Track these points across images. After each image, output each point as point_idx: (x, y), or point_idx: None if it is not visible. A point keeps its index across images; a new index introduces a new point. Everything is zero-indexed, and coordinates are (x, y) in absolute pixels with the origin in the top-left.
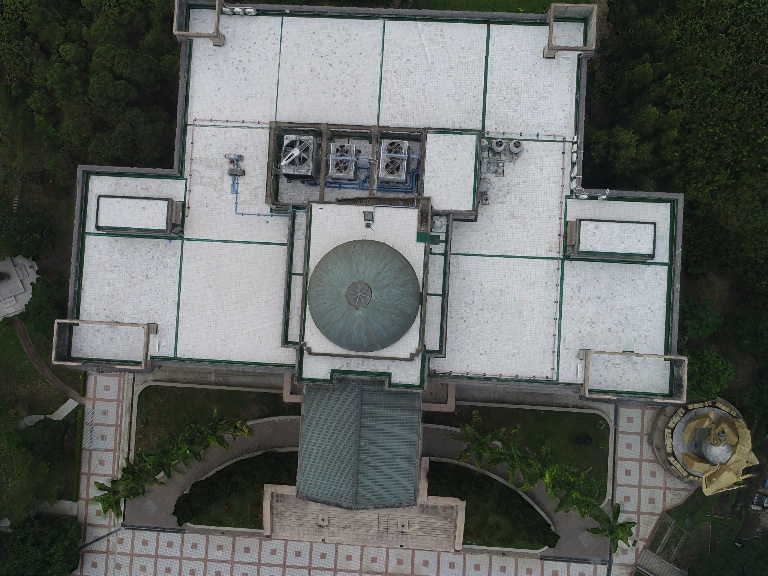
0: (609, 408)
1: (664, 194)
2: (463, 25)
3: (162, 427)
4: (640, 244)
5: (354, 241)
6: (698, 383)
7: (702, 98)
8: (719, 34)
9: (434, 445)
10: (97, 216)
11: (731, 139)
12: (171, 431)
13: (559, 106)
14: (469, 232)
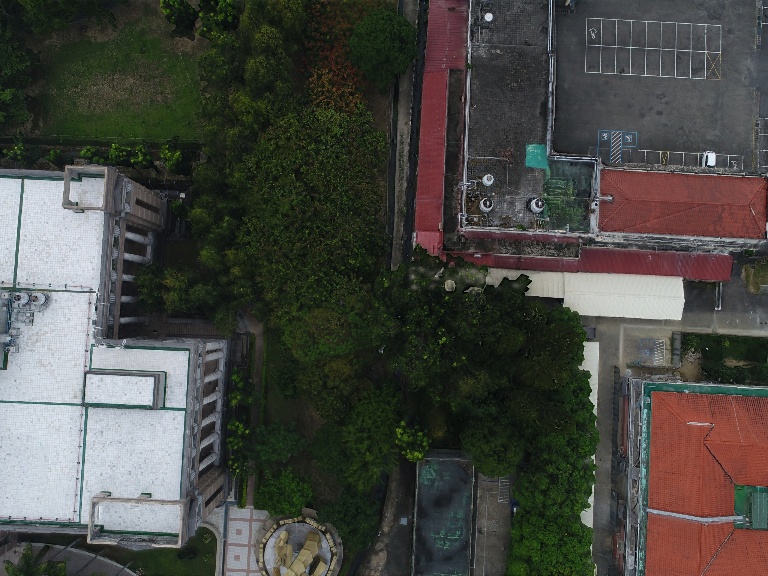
0: (219, 521)
1: (177, 344)
2: None
3: None
4: (141, 396)
5: None
6: None
7: (267, 236)
8: (289, 174)
9: None
10: None
11: (297, 274)
12: None
13: (87, 258)
14: None
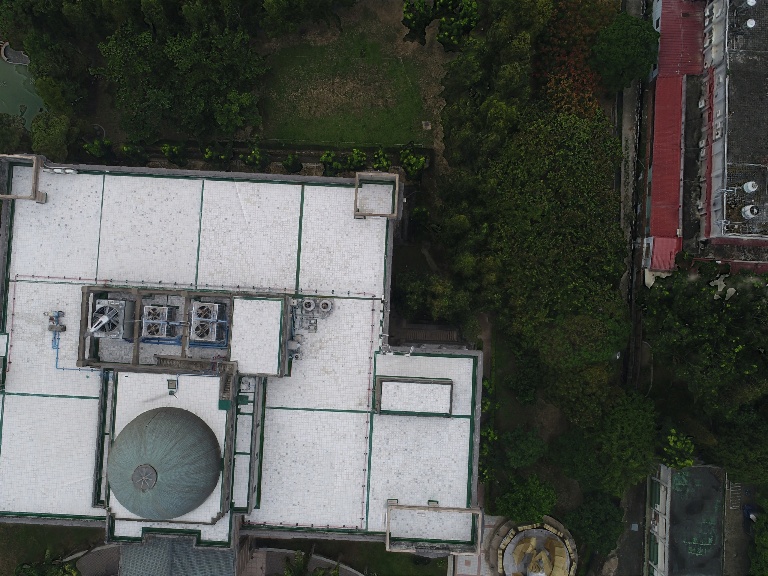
0: None
1: (465, 352)
2: (279, 186)
3: (11, 552)
4: (438, 404)
5: (152, 414)
6: (523, 509)
7: (520, 242)
8: (538, 180)
9: (277, 568)
10: None
11: (548, 280)
12: (20, 556)
13: (369, 265)
14: (283, 386)
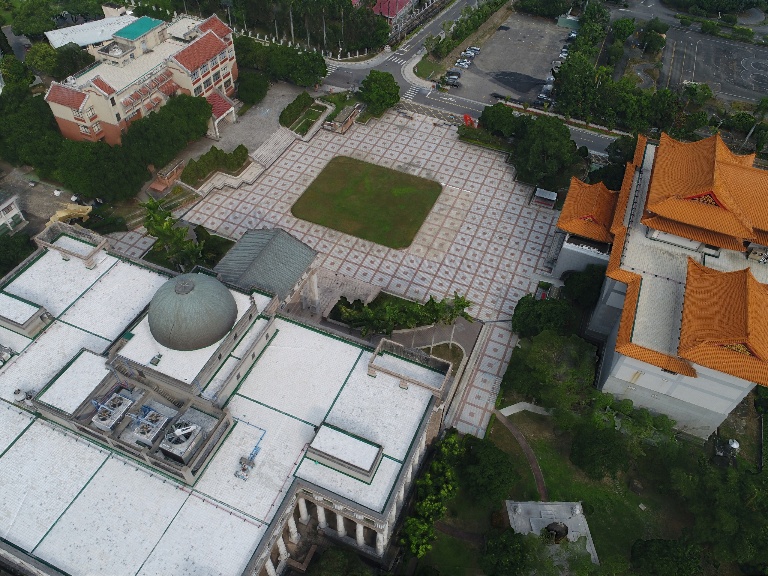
0: None
1: None
2: None
3: None
4: (0, 300)
5: (173, 339)
6: None
7: None
8: None
9: None
10: (377, 456)
11: None
12: None
13: None
14: None
